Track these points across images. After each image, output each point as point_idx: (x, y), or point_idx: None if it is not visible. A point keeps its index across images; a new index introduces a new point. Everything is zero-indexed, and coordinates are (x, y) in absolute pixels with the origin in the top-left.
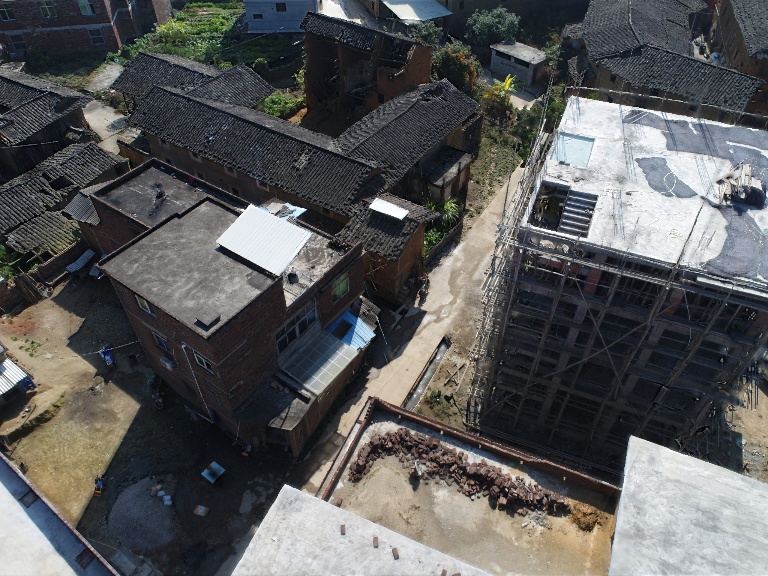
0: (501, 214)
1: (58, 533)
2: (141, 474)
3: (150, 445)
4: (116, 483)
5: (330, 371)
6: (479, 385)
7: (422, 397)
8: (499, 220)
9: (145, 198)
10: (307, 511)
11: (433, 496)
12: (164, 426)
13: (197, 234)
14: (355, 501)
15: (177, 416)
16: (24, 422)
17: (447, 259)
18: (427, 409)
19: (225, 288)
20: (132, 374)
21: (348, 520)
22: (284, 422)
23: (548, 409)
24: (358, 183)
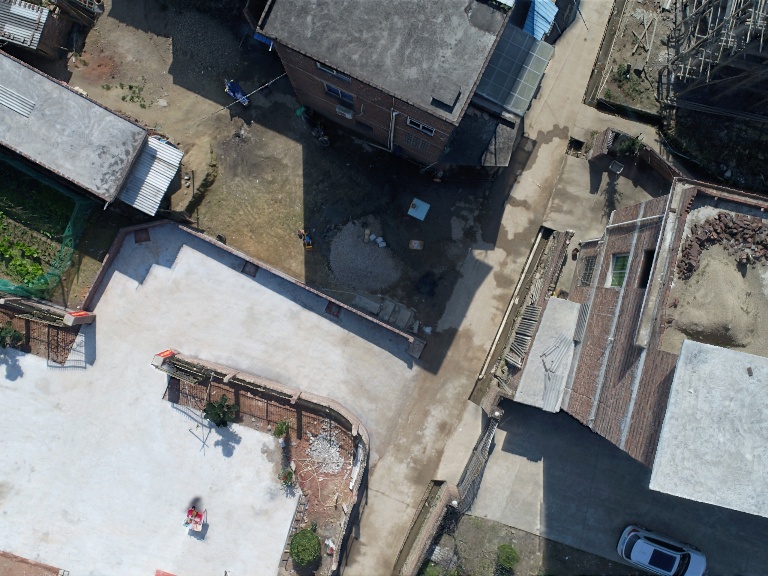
0: None
1: (297, 293)
2: (341, 220)
3: (335, 188)
4: (321, 234)
5: (528, 81)
6: (691, 62)
7: (608, 74)
8: None
9: None
10: (713, 361)
11: (761, 279)
12: (339, 165)
13: None
14: (694, 301)
15: (349, 151)
16: (193, 192)
17: None
18: (615, 89)
19: (446, 39)
20: (272, 107)
21: (753, 362)
22: (496, 157)
23: (766, 78)
24: None
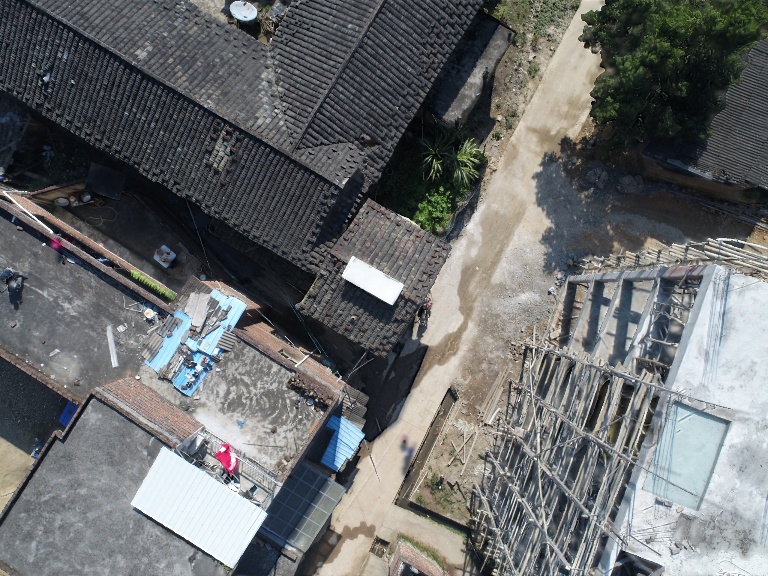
0: (544, 131)
1: None
2: None
3: None
4: None
5: (315, 519)
6: None
7: (422, 480)
8: (540, 147)
9: None
10: None
11: None
12: None
13: (99, 477)
14: None
15: None
16: None
17: (457, 244)
18: (427, 495)
19: None
20: None
21: None
22: None
23: None
24: (320, 215)
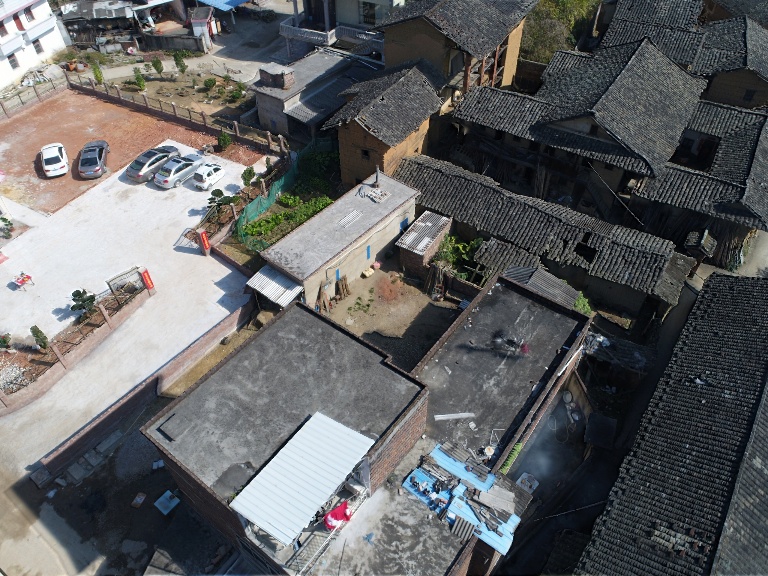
0: None
1: None
2: None
3: None
4: None
5: None
6: None
7: None
8: None
9: (506, 329)
10: None
11: None
12: None
13: (345, 388)
14: None
15: None
16: None
17: None
18: None
19: (229, 438)
20: None
21: None
22: (159, 569)
23: None
24: None
